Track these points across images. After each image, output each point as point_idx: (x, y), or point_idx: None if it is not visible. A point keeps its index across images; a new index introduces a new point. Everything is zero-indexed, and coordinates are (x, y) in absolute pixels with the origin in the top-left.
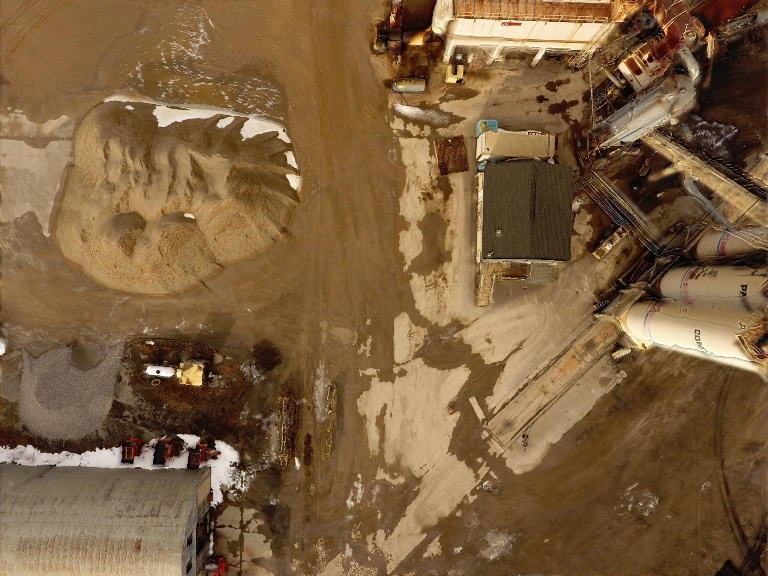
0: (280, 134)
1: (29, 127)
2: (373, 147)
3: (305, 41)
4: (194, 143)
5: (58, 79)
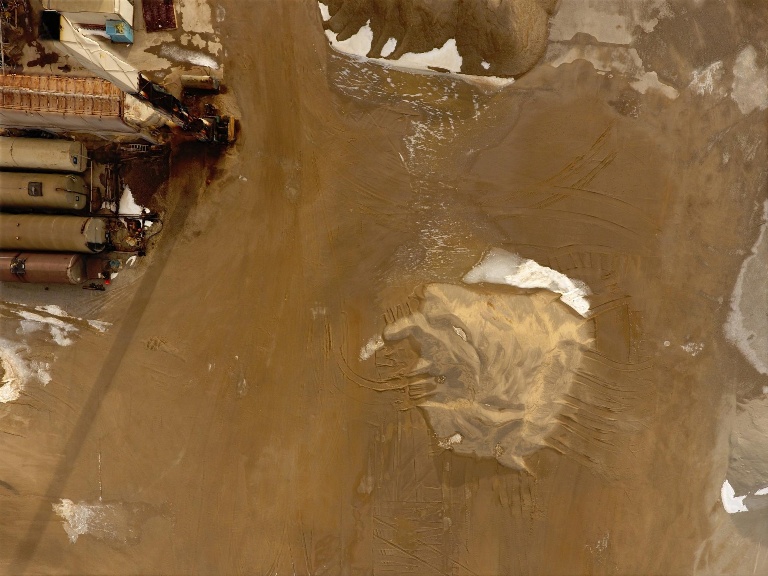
0: (335, 39)
1: (592, 56)
2: (240, 24)
3: (307, 135)
4: (413, 2)
5: (559, 105)
